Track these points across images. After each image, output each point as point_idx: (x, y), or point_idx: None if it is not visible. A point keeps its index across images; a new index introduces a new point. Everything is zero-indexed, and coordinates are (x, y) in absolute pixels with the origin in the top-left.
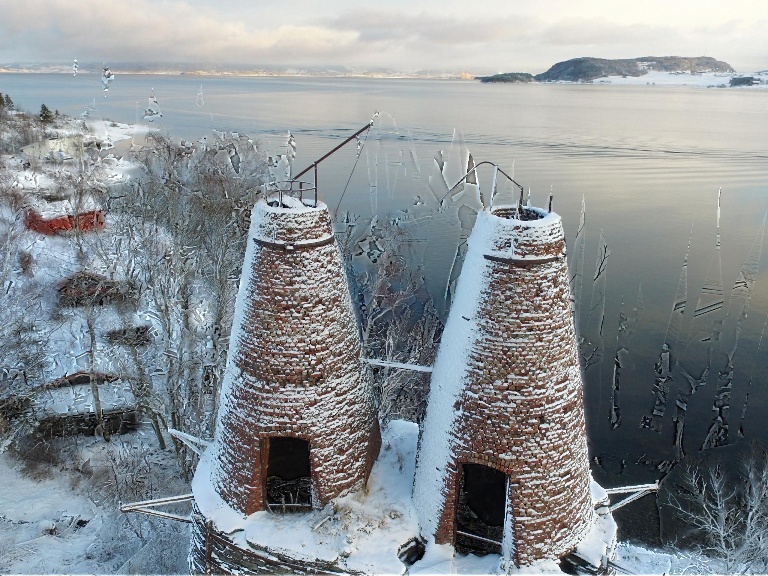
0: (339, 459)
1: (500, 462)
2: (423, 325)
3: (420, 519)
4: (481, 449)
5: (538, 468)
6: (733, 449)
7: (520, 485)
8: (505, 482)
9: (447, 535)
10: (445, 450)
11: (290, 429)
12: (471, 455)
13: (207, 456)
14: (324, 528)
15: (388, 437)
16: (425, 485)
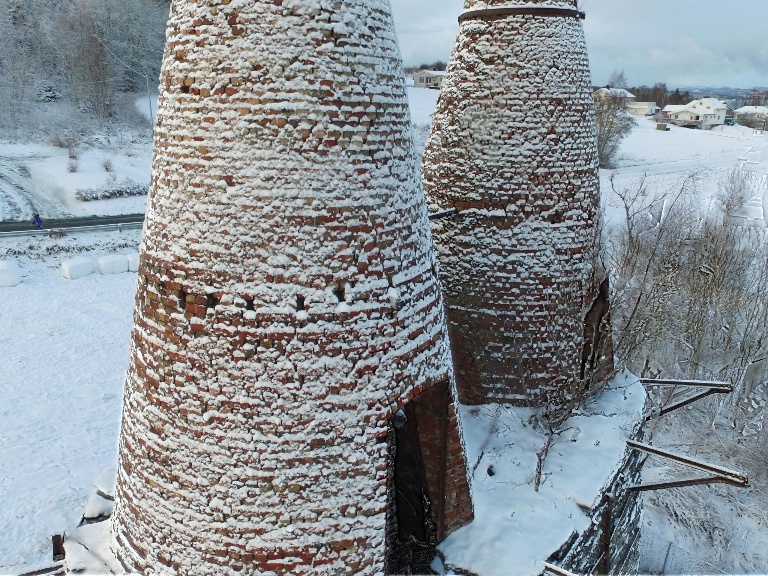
0: None
1: None
2: None
3: None
4: None
5: None
6: None
7: None
8: None
9: None
10: None
11: None
12: None
13: None
14: None
15: (506, 419)
16: None
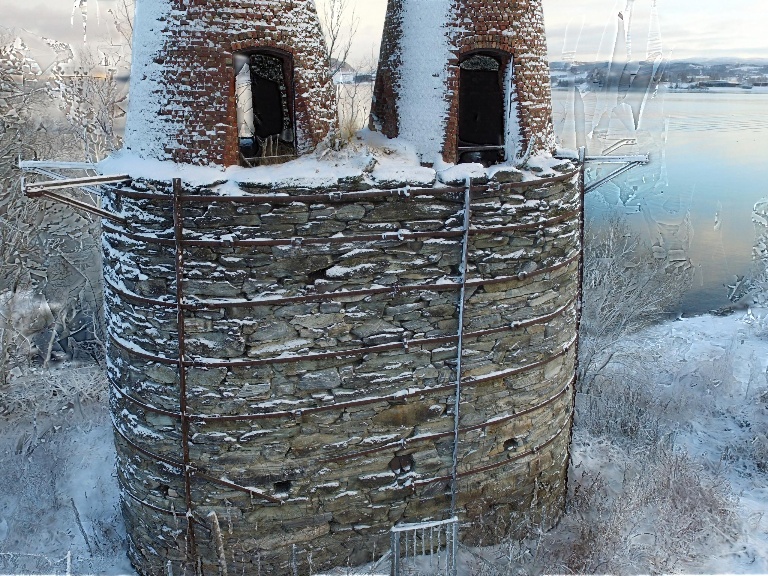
0: (321, 89)
1: (504, 40)
2: (332, 9)
3: (418, 146)
4: (484, 29)
5: (533, 48)
6: None
7: (522, 65)
8: (499, 79)
9: (451, 152)
10: (442, 47)
11: (270, 36)
12: (474, 40)
13: (115, 153)
14: (331, 155)
15: None
16: (419, 105)
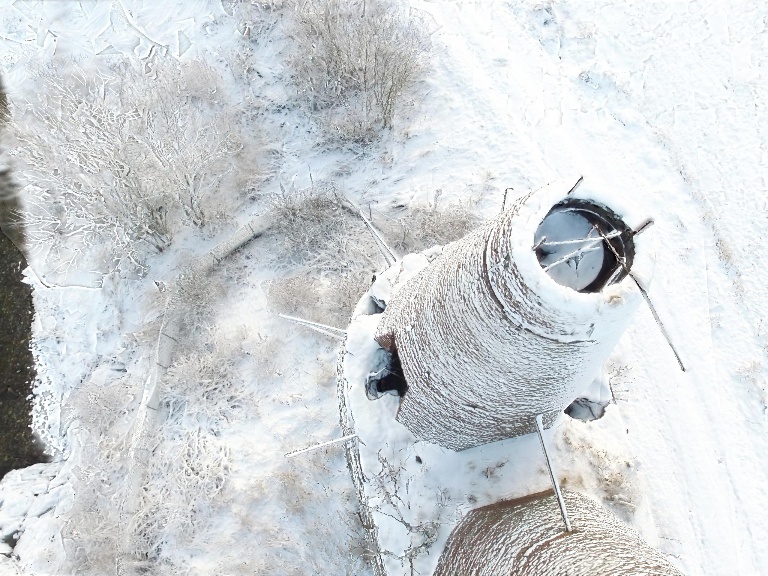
0: None
1: None
2: None
3: None
4: None
5: None
6: (2, 189)
7: None
8: None
9: None
10: None
11: None
12: None
13: None
14: None
15: (451, 511)
16: None
